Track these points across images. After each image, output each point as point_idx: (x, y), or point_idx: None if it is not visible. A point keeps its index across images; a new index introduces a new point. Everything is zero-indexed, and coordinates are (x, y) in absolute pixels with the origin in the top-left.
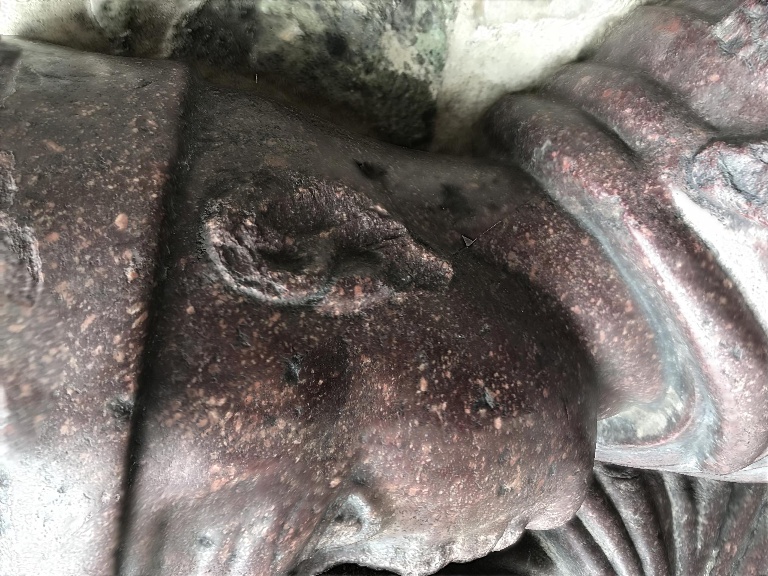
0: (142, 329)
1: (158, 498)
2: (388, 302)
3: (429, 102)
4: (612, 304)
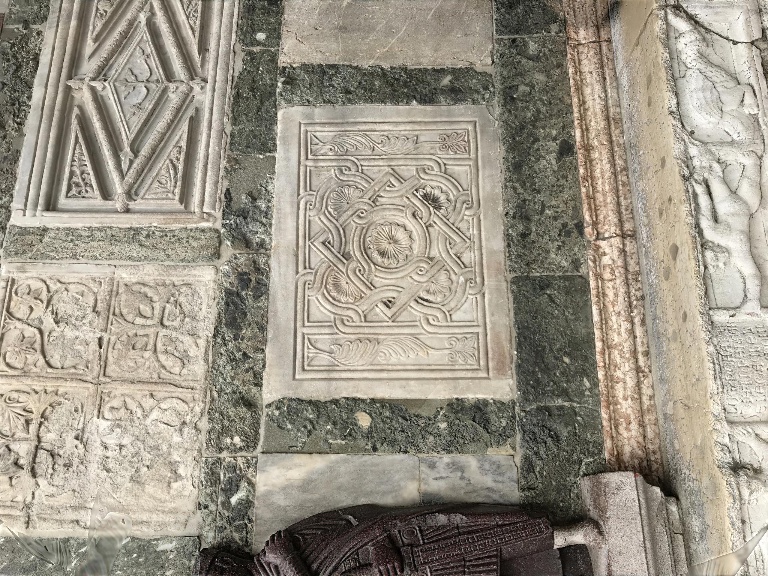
0: (209, 565)
1: None
2: (230, 567)
3: (250, 555)
4: (257, 572)
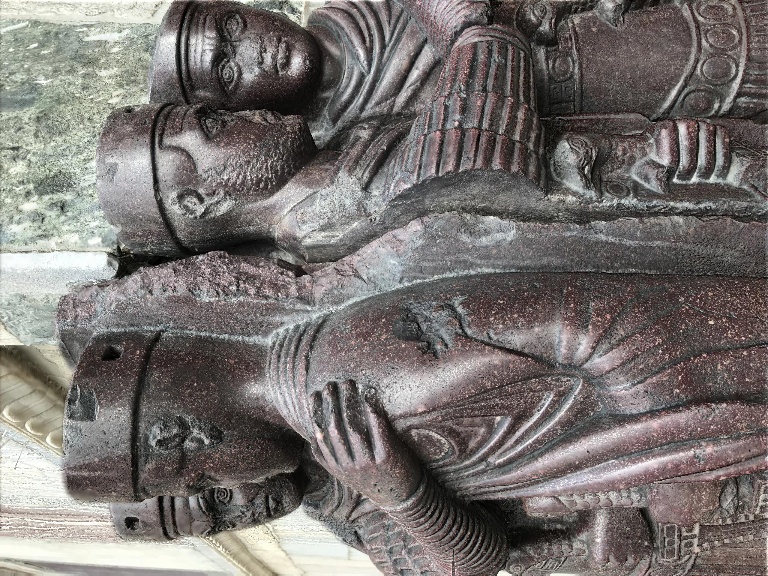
0: None
1: (199, 2)
2: None
3: None
4: None
